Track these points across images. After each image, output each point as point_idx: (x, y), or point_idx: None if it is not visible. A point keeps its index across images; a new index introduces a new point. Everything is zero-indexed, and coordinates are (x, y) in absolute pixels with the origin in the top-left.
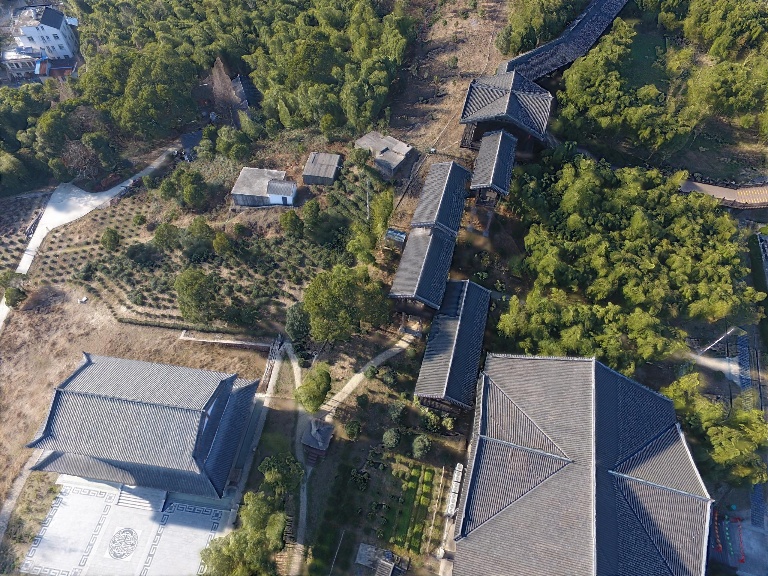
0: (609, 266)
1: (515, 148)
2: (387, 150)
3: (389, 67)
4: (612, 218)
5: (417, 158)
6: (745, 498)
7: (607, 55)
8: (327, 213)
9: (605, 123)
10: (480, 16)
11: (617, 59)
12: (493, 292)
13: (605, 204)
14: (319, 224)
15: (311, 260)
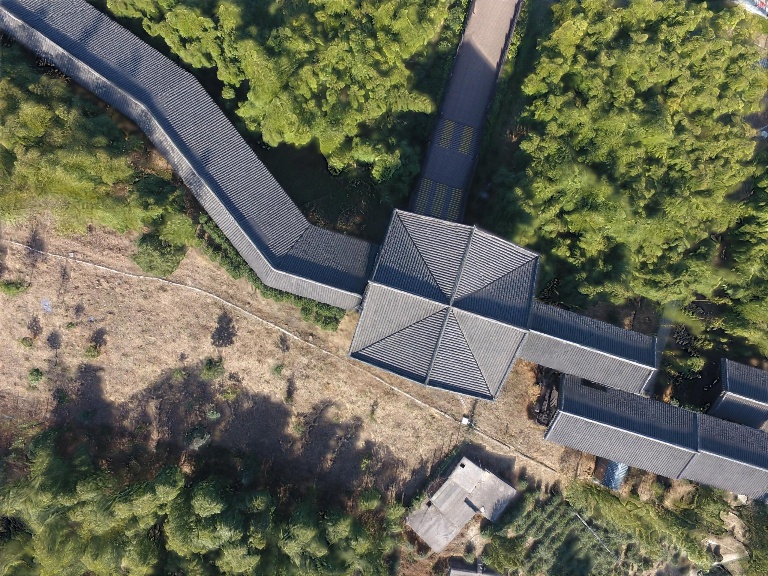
0: (701, 196)
1: (540, 304)
2: (468, 500)
3: (247, 513)
4: (640, 170)
5: (478, 446)
6: None
7: (222, 33)
8: (549, 569)
9: (428, 108)
10: (22, 290)
11: None
12: (660, 335)
13: (619, 173)
14: (563, 575)
15: (605, 573)
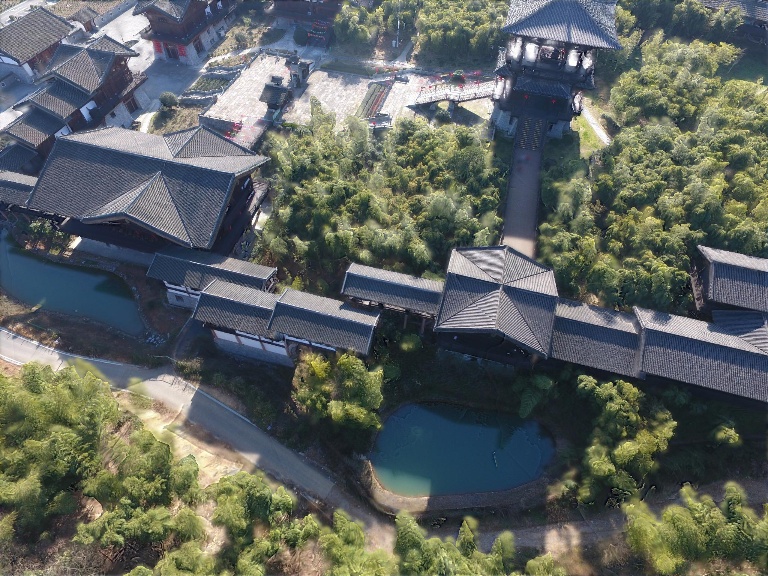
0: None
1: None
2: None
3: None
4: None
5: None
6: (334, 54)
7: None
8: None
9: None
10: None
11: (658, 0)
12: None
13: None
14: None
15: None
